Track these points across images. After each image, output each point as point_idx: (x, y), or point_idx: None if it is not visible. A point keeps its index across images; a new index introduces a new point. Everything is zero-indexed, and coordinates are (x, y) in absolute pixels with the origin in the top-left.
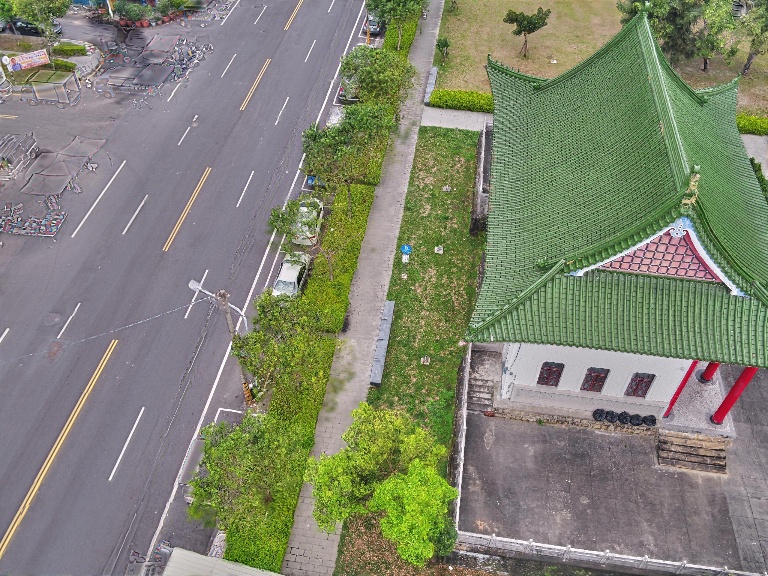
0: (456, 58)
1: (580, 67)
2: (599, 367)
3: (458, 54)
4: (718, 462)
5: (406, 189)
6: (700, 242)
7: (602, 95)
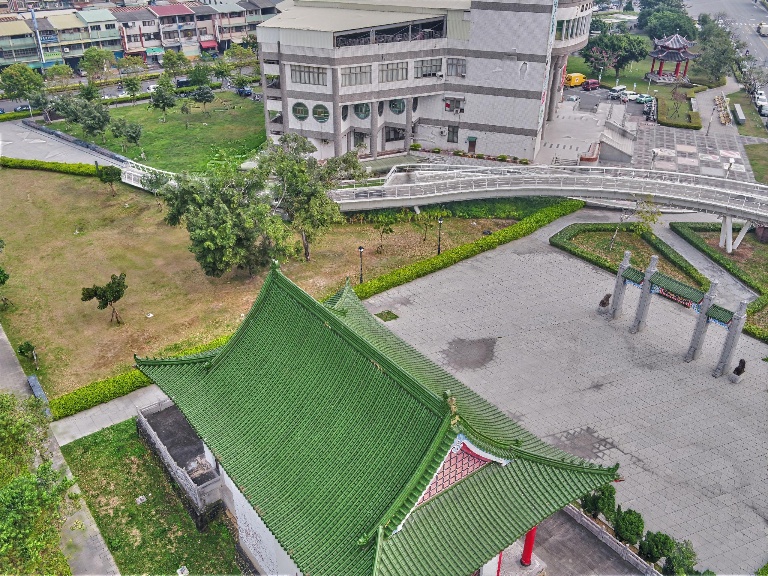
0: (47, 355)
1: (240, 332)
2: None
3: (46, 350)
4: None
5: (96, 527)
6: (474, 445)
7: (285, 351)
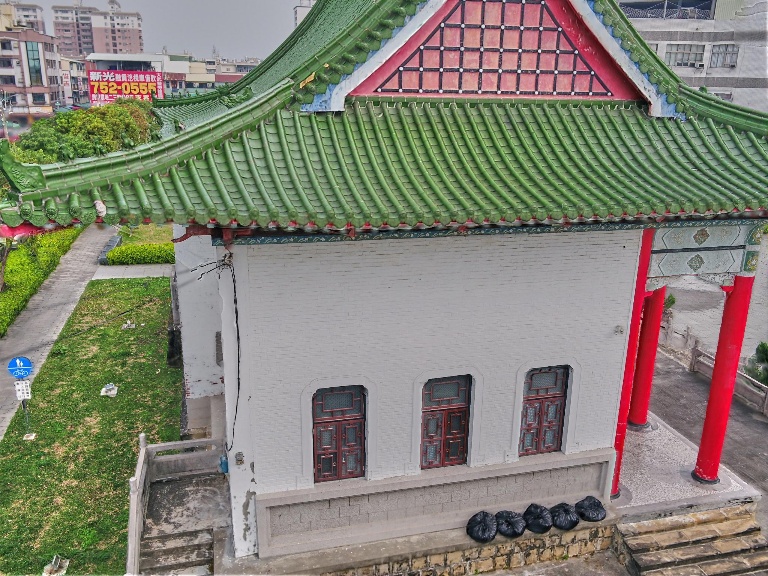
0: None
1: (280, 53)
2: (446, 374)
3: None
4: (764, 558)
5: (56, 336)
6: None
7: None
